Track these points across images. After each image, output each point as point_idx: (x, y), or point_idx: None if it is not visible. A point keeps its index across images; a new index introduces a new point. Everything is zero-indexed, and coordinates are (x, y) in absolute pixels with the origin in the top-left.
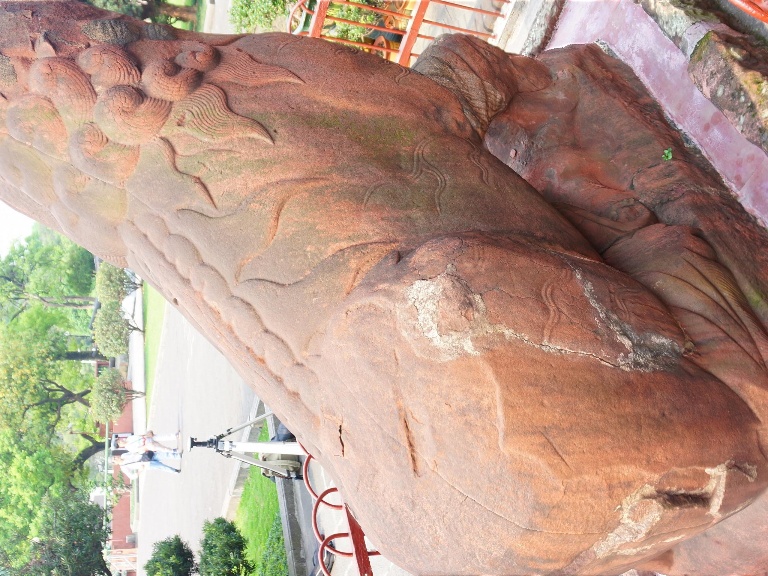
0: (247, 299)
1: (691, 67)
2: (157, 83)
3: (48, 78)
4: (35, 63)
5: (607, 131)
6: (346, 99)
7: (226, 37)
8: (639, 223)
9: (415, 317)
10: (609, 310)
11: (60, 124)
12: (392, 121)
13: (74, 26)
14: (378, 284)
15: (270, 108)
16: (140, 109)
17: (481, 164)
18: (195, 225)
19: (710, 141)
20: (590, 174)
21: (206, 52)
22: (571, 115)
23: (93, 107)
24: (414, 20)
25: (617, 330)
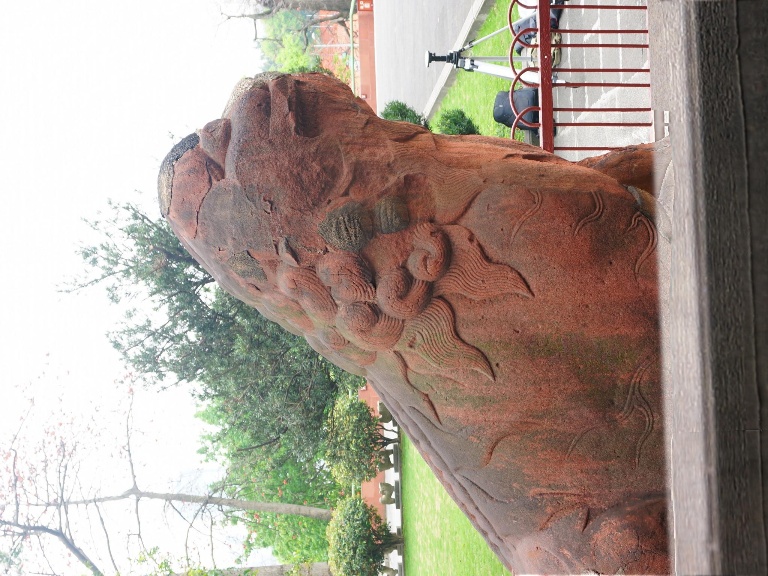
0: (463, 485)
1: None
2: (390, 307)
3: (294, 291)
4: (281, 268)
5: None
6: (573, 319)
7: (459, 204)
8: None
9: None
10: None
11: (308, 320)
12: (617, 342)
13: (311, 225)
14: (564, 548)
15: (495, 335)
16: (376, 329)
17: None
18: (423, 426)
19: None
20: None
21: (437, 259)
22: None
23: (335, 316)
24: None
25: None
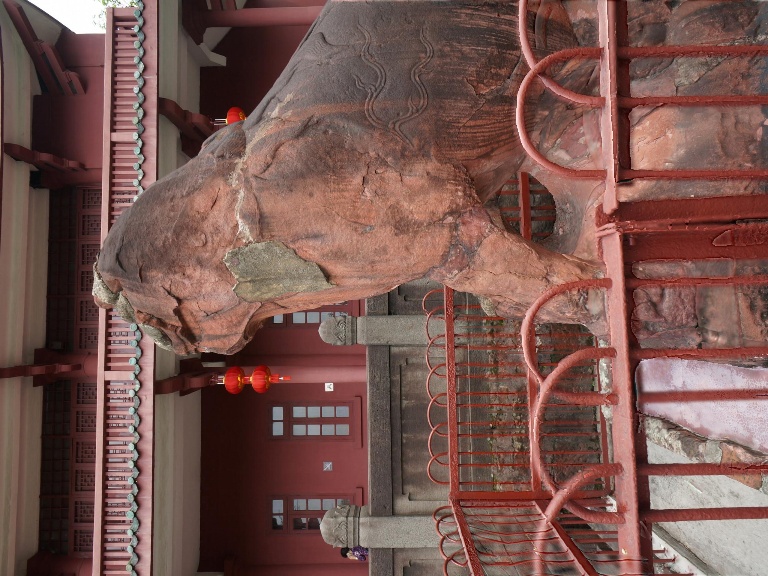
0: None
1: None
2: None
3: None
4: None
5: None
6: None
7: None
8: None
9: None
10: None
11: None
12: None
13: None
14: None
15: None
16: None
17: None
18: None
19: None
20: None
21: None
22: None
23: None
24: None
25: None
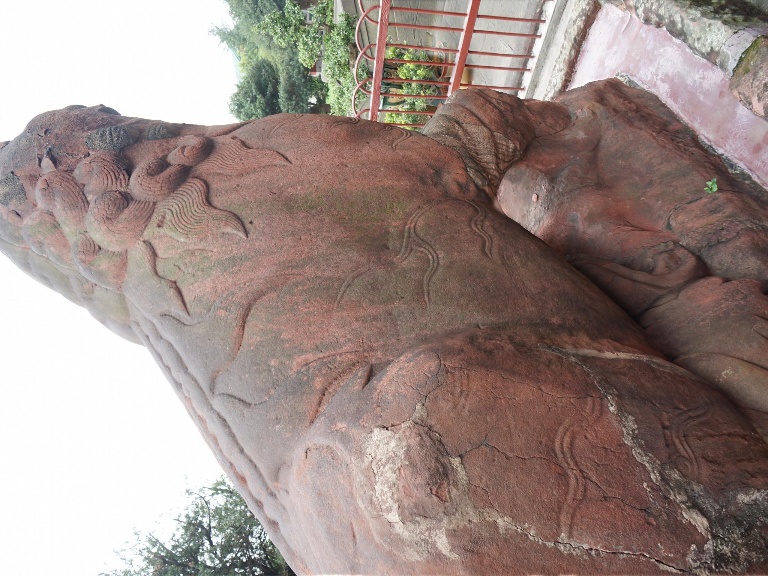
0: (222, 414)
1: (734, 83)
2: (140, 185)
3: (45, 193)
4: None
5: (634, 166)
6: (332, 175)
7: (228, 126)
8: (684, 275)
9: (372, 485)
10: (665, 464)
11: (62, 236)
12: (382, 193)
13: (78, 138)
14: (336, 421)
15: (250, 197)
16: (123, 214)
17: (484, 231)
18: (173, 333)
19: (763, 164)
20: (618, 215)
21: (195, 145)
22: (593, 153)
23: (86, 216)
24: (453, 85)
25: (681, 501)
